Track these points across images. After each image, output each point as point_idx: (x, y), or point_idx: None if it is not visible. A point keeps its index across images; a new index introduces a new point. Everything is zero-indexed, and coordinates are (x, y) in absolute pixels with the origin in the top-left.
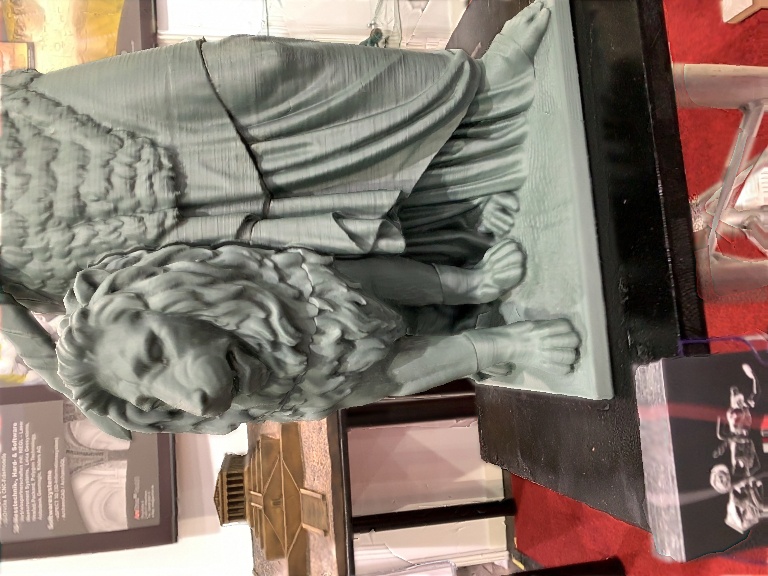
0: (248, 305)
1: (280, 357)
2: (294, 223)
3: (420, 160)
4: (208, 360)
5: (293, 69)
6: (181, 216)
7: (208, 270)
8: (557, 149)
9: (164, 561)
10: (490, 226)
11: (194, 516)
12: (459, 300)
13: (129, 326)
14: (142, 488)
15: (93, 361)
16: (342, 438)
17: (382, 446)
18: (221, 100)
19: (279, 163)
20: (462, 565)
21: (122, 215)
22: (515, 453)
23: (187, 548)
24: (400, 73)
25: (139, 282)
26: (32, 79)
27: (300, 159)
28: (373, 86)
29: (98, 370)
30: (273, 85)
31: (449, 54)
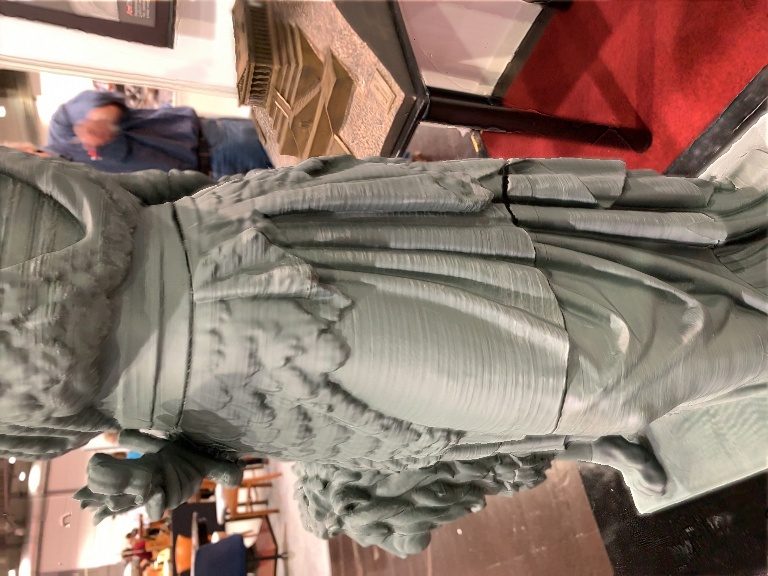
0: None
1: None
2: None
3: None
4: (421, 541)
5: None
6: None
7: None
8: None
9: (156, 56)
10: None
11: (189, 16)
12: None
13: None
14: None
15: None
16: (401, 150)
17: (406, 8)
18: None
19: None
20: None
21: None
22: None
23: (178, 44)
24: None
25: (392, 519)
26: (336, 369)
27: None
28: None
29: None
30: None
31: None
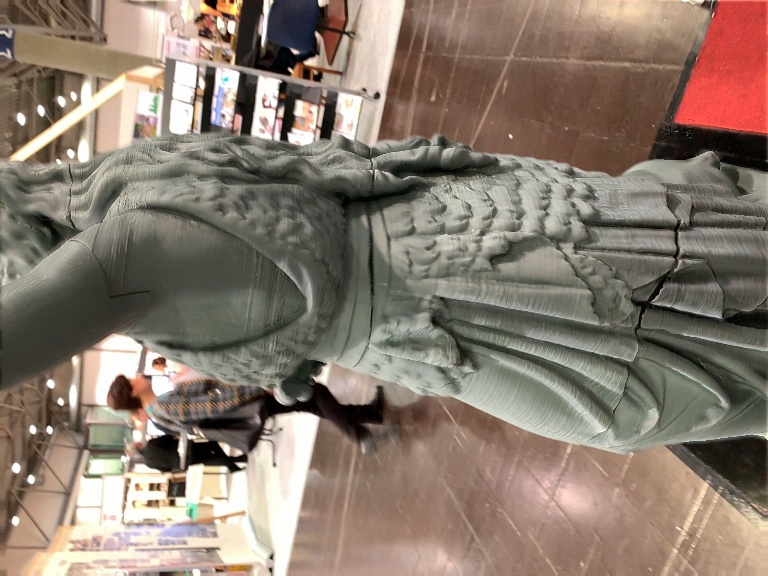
0: None
1: None
2: None
3: None
4: None
5: None
6: None
7: None
8: None
9: None
10: None
11: None
12: None
13: None
14: None
15: None
16: None
17: None
18: None
19: None
20: None
21: None
22: None
23: None
24: None
25: None
26: None
27: None
28: None
29: None
30: None
31: None
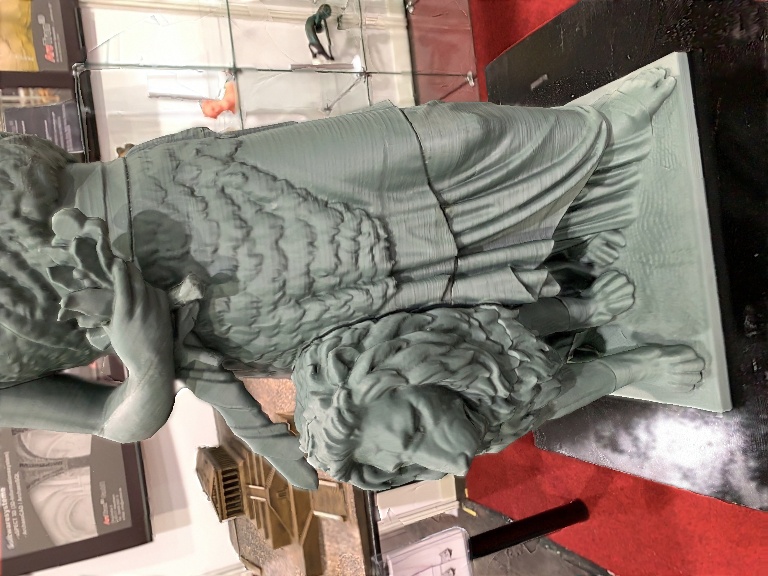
0: (479, 368)
1: (495, 408)
2: (484, 281)
3: (560, 209)
4: (462, 424)
5: (487, 139)
6: (397, 284)
7: (443, 339)
8: (679, 201)
9: (138, 561)
10: (594, 258)
11: (162, 512)
12: (577, 327)
13: (390, 401)
14: (109, 492)
15: (358, 437)
16: None
17: None
18: (427, 170)
19: (467, 224)
20: (419, 519)
21: (346, 288)
22: (588, 444)
23: (158, 544)
24: (556, 134)
25: (393, 358)
26: (236, 149)
27: (483, 219)
28: (540, 148)
29: (360, 444)
30: (470, 154)
31: (584, 112)
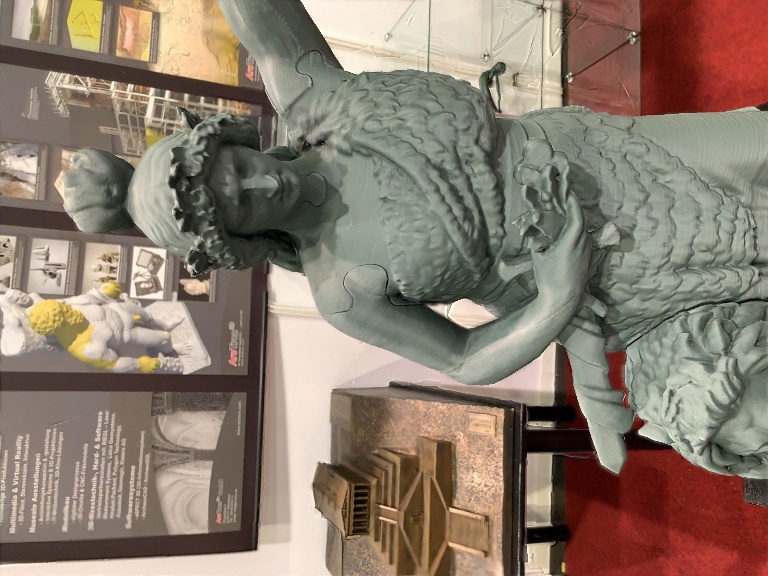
0: None
1: None
2: None
3: None
4: None
5: None
6: None
7: None
8: None
9: (238, 568)
10: None
11: (266, 523)
12: None
13: None
14: (225, 491)
15: (737, 407)
16: (521, 463)
17: None
18: None
19: None
20: None
21: (717, 267)
22: None
23: (256, 556)
24: None
25: None
26: (633, 124)
27: None
28: None
29: (736, 415)
30: None
31: None
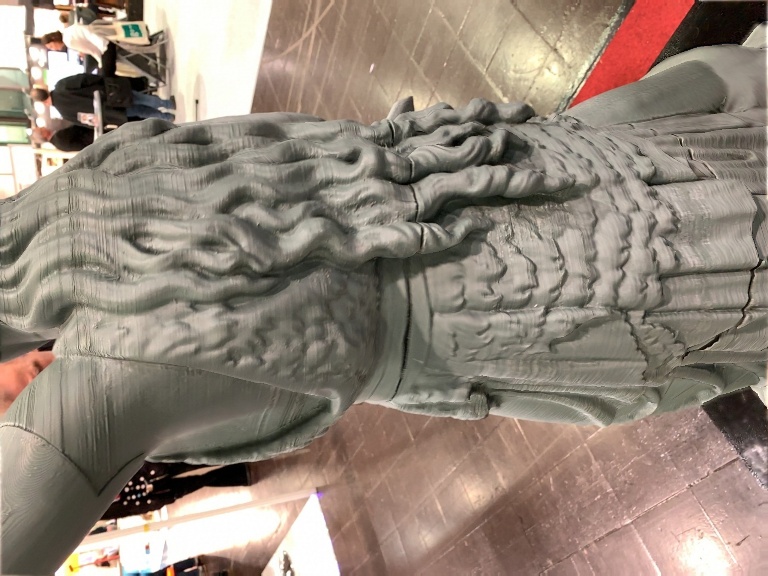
0: None
1: None
2: None
3: None
4: None
5: None
6: None
7: None
8: None
9: None
10: None
11: None
12: None
13: None
14: None
15: None
16: None
17: None
18: None
19: None
20: None
21: None
22: (683, 45)
23: None
24: None
25: None
26: None
27: None
28: None
29: None
30: None
31: None
